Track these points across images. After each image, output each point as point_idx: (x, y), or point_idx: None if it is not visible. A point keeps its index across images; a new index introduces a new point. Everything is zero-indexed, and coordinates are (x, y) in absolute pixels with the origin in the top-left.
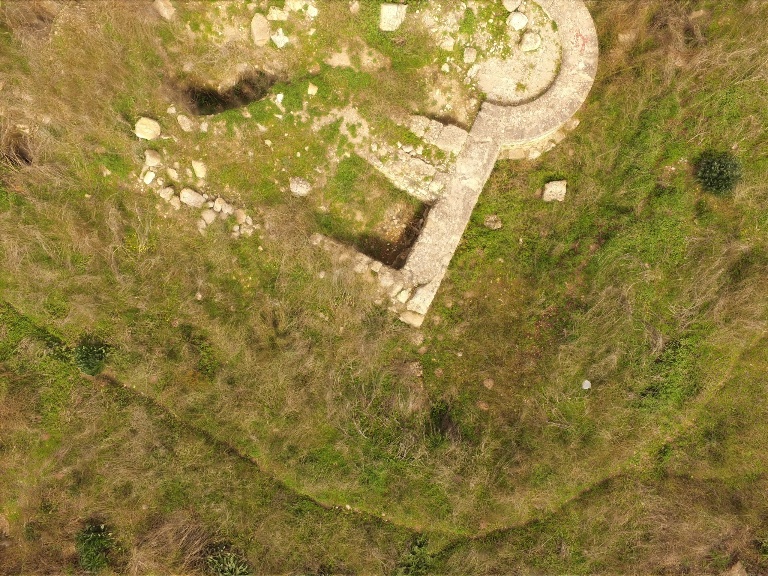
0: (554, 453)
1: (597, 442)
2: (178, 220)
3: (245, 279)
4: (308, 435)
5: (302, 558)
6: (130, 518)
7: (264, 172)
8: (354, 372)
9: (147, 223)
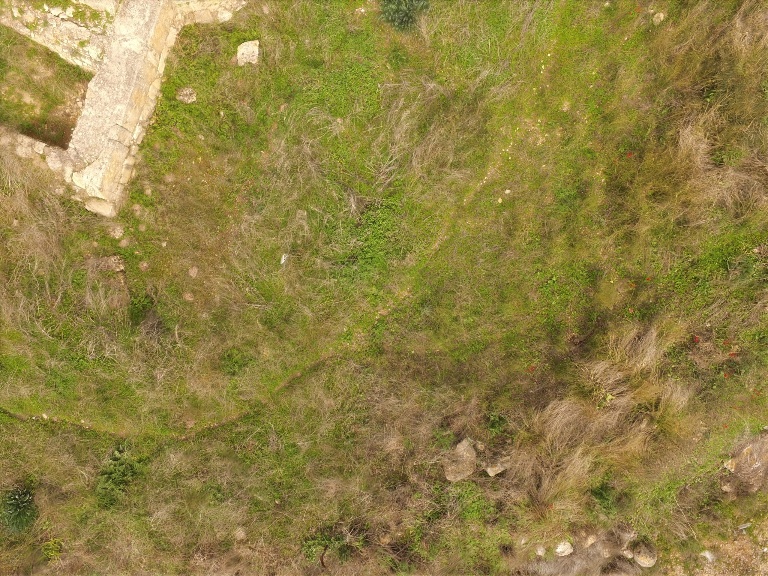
0: (237, 332)
1: (299, 321)
2: None
3: None
4: None
5: None
6: None
7: None
8: (33, 268)
9: None
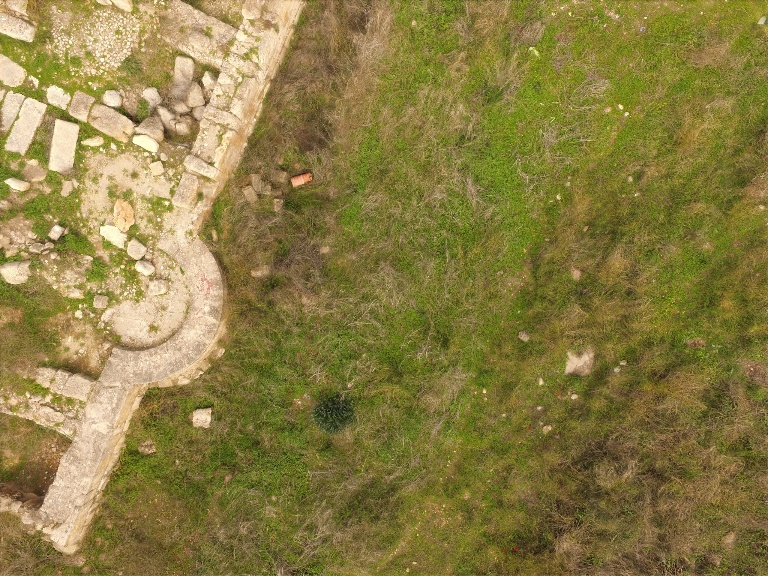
0: None
1: None
2: None
3: None
4: None
5: None
6: None
7: None
8: None
9: None
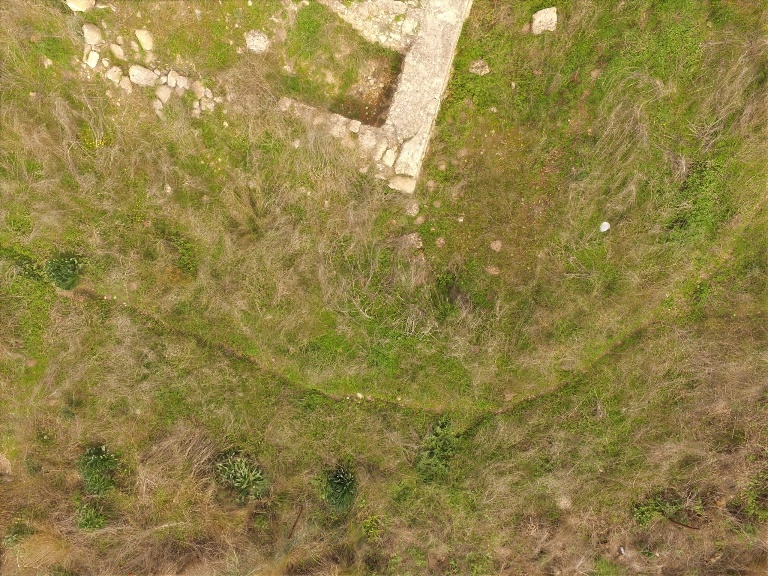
0: (577, 301)
1: (624, 288)
2: (133, 106)
3: (214, 162)
4: (305, 321)
5: (318, 456)
6: (131, 436)
7: (216, 32)
8: (346, 248)
9: (100, 113)
